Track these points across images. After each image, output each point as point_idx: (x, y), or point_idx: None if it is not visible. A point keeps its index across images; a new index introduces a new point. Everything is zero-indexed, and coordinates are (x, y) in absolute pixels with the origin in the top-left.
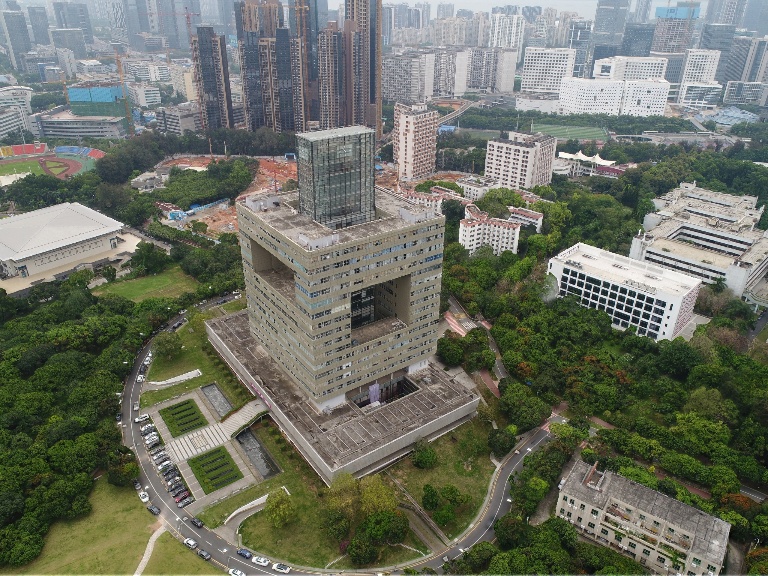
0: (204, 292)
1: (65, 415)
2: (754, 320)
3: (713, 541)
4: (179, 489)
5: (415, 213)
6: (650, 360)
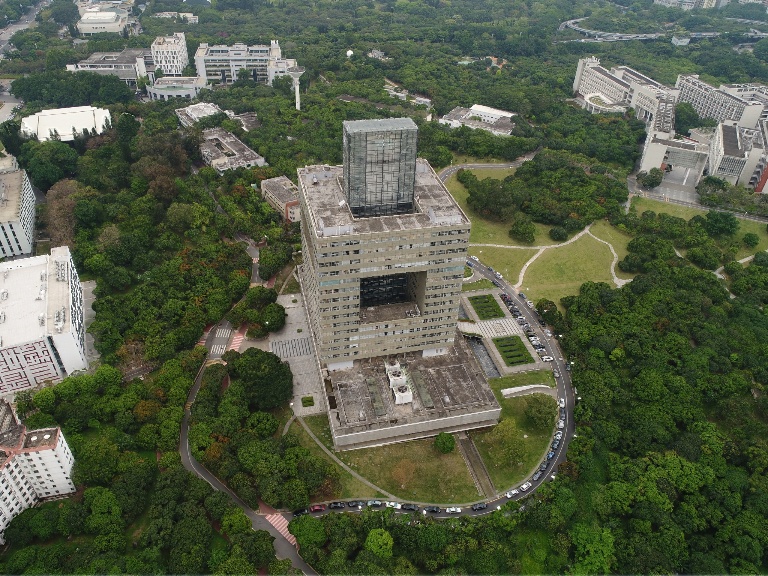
0: (507, 506)
1: (614, 370)
2: (2, 258)
3: (276, 180)
4: (509, 299)
5: (325, 165)
6: (145, 256)
